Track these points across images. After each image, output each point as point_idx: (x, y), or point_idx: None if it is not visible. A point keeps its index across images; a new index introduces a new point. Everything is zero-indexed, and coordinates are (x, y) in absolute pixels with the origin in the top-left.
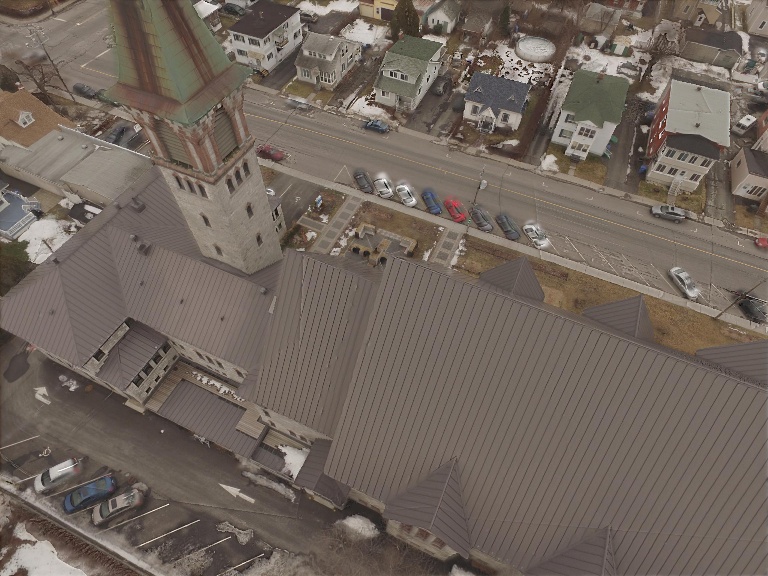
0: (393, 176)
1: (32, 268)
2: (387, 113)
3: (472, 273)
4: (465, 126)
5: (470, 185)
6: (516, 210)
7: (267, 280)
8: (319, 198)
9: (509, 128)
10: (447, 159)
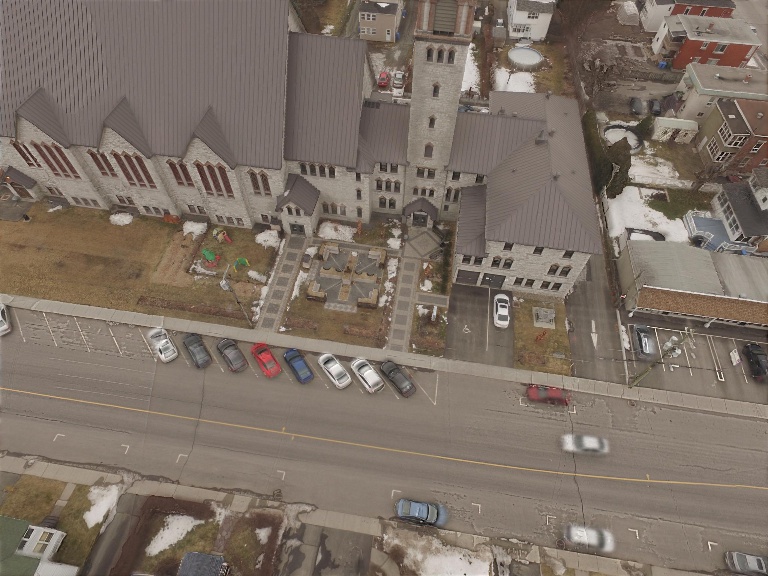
0: (360, 401)
1: (609, 161)
2: (414, 567)
3: (245, 281)
4: (253, 571)
5: (245, 412)
6: (182, 382)
7: (401, 117)
8: (434, 311)
9: (161, 570)
10: (283, 464)
